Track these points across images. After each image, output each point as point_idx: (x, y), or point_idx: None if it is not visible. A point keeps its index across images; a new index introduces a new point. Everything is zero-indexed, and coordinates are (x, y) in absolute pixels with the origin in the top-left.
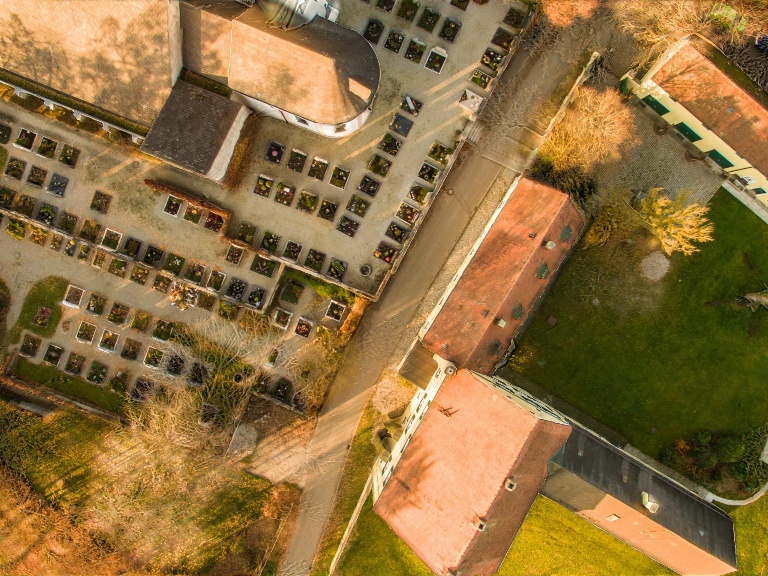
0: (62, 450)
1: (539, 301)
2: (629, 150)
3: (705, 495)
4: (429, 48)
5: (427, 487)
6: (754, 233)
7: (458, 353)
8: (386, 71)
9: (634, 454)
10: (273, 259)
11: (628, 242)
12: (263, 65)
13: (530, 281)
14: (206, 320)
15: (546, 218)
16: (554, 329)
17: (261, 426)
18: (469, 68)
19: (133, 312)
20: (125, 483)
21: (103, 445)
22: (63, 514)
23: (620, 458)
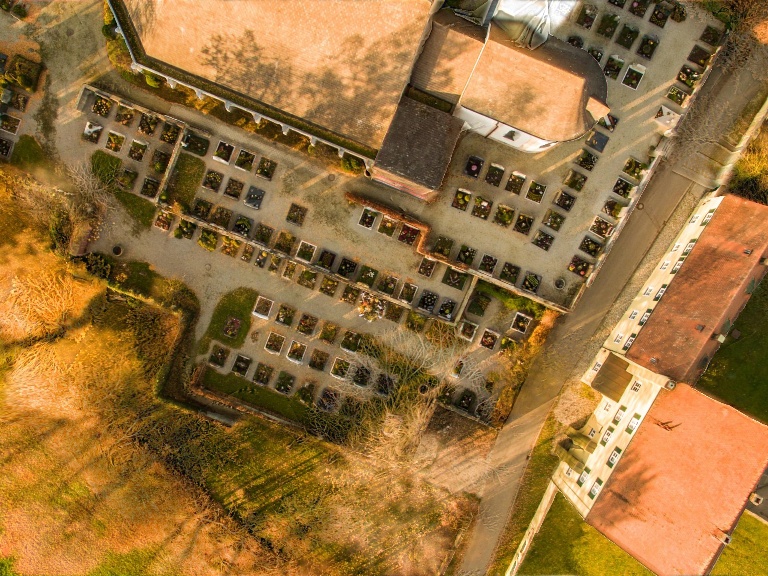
0: (243, 460)
1: None
2: None
3: None
4: (626, 65)
5: (651, 500)
6: None
7: (672, 367)
8: None
9: None
10: (468, 272)
11: None
12: (504, 83)
13: (740, 296)
14: (393, 332)
15: (763, 235)
16: (738, 342)
17: (442, 437)
18: (665, 85)
19: (321, 323)
20: (305, 493)
21: (284, 455)
22: (241, 523)
23: None
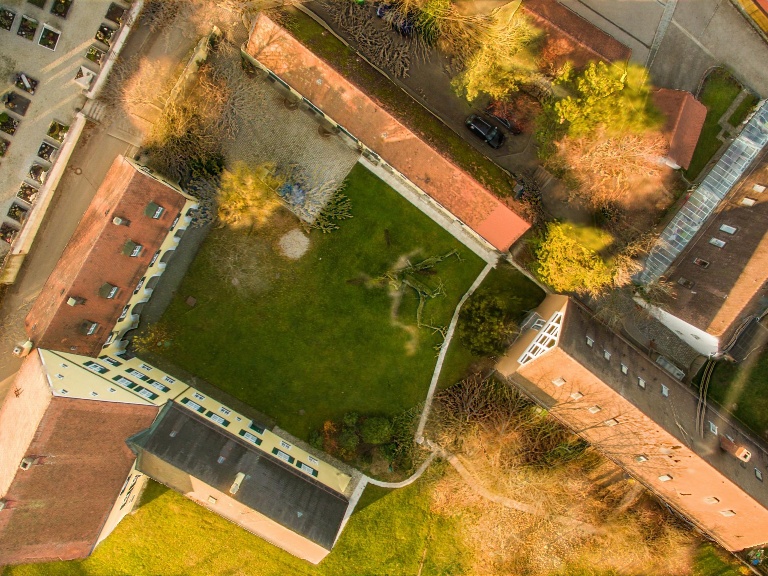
0: None
1: (177, 281)
2: (260, 126)
3: (359, 477)
4: (42, 25)
5: None
6: (394, 209)
7: (38, 333)
8: None
9: (283, 436)
10: None
11: (263, 220)
12: None
13: (117, 259)
14: None
15: (118, 194)
16: (194, 310)
17: None
18: (84, 44)
19: None
20: None
21: None
22: None
23: (225, 439)
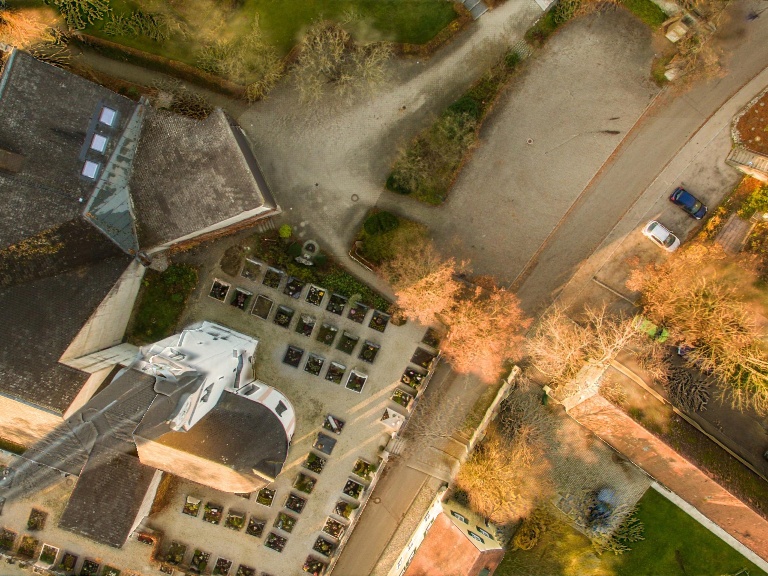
0: None
1: None
2: (555, 454)
3: None
4: (349, 369)
5: None
6: (686, 531)
7: None
8: (307, 393)
9: None
10: None
11: (557, 545)
12: (169, 457)
13: None
14: None
15: (460, 571)
16: None
17: None
18: (390, 387)
19: None
20: None
21: None
22: None
23: None
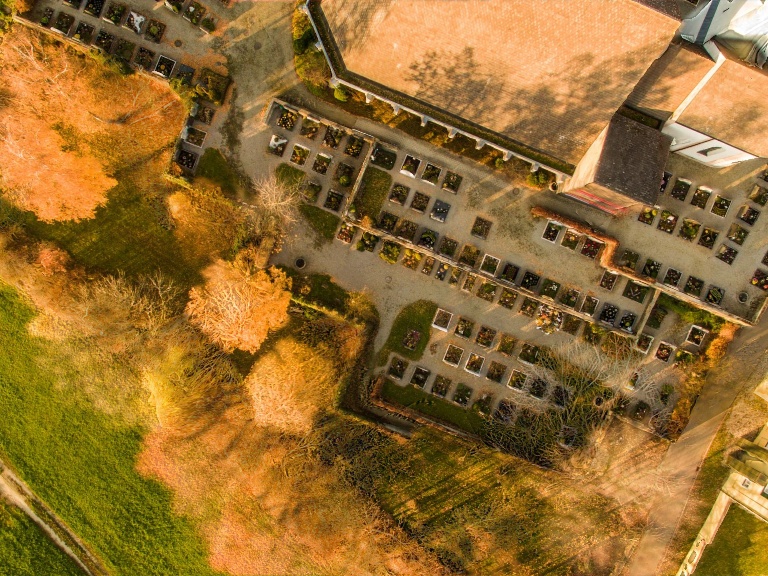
0: (415, 471)
1: None
2: None
3: None
4: None
5: None
6: None
7: None
8: None
9: None
10: (651, 285)
11: None
12: (730, 102)
13: None
14: (570, 344)
15: None
16: None
17: (613, 448)
18: None
19: (499, 336)
20: (475, 503)
21: (456, 466)
22: (411, 534)
23: None
